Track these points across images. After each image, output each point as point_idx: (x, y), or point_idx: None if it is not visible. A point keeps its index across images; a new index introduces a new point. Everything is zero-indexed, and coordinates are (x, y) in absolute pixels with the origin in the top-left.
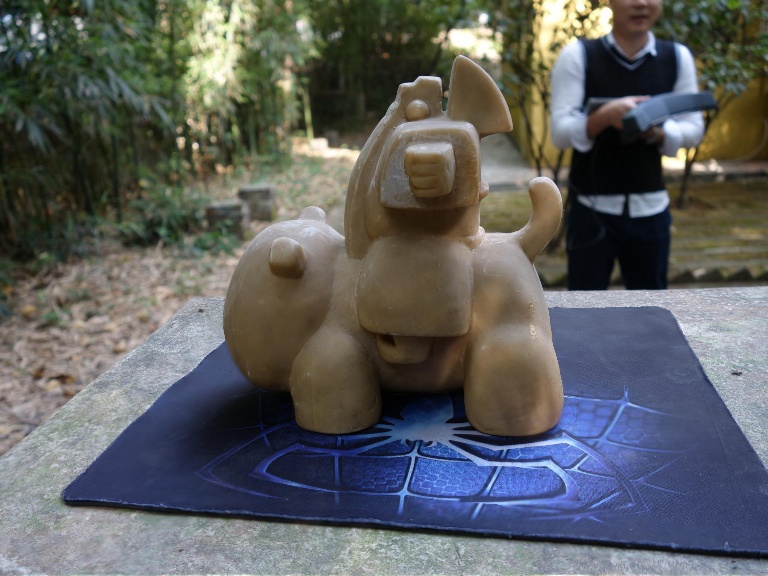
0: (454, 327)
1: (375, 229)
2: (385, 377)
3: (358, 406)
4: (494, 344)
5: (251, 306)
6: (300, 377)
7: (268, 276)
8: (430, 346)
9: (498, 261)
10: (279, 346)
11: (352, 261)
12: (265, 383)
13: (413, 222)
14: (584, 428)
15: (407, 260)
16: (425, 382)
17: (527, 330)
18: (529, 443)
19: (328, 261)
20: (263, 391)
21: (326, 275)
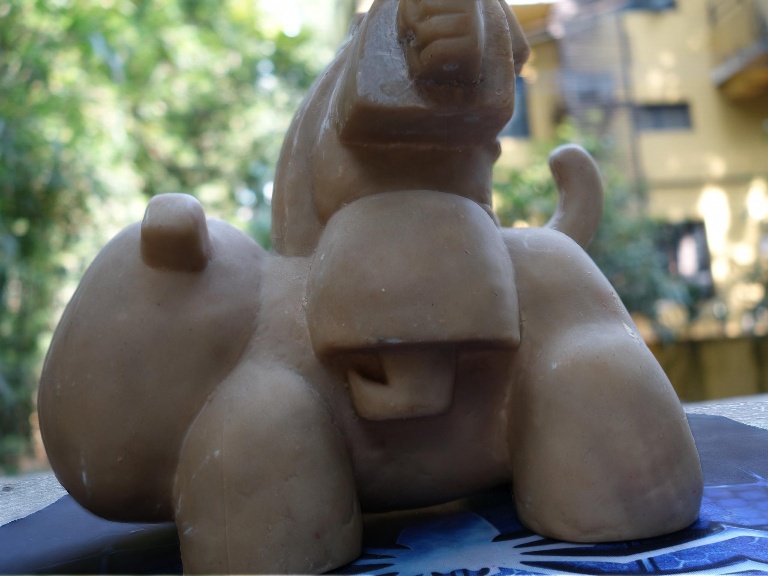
0: (503, 322)
1: (333, 193)
2: (362, 469)
3: (323, 513)
4: (574, 355)
5: (99, 327)
6: (198, 465)
7: (137, 270)
8: (453, 378)
9: (543, 234)
10: (154, 403)
11: (292, 259)
12: (119, 495)
13: (401, 169)
14: (749, 515)
15: (404, 210)
16: (438, 472)
17: (622, 330)
18: (678, 544)
19: (249, 257)
20: (111, 552)
21: (248, 274)
